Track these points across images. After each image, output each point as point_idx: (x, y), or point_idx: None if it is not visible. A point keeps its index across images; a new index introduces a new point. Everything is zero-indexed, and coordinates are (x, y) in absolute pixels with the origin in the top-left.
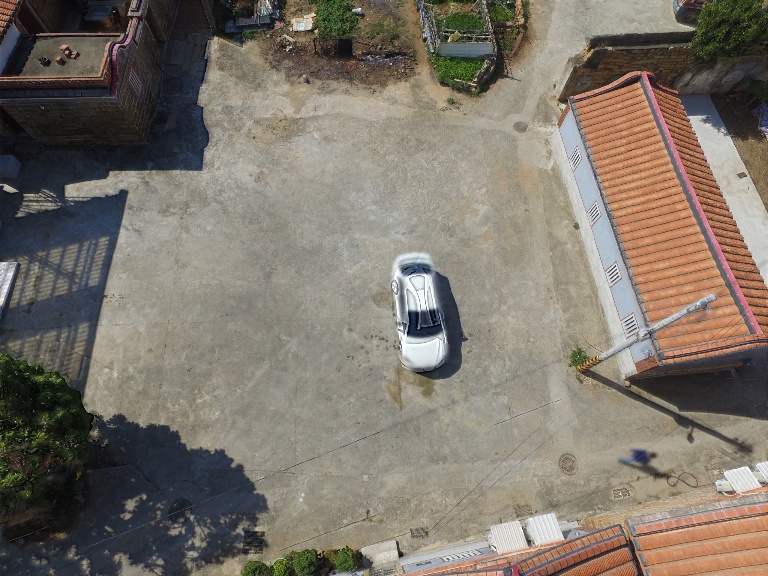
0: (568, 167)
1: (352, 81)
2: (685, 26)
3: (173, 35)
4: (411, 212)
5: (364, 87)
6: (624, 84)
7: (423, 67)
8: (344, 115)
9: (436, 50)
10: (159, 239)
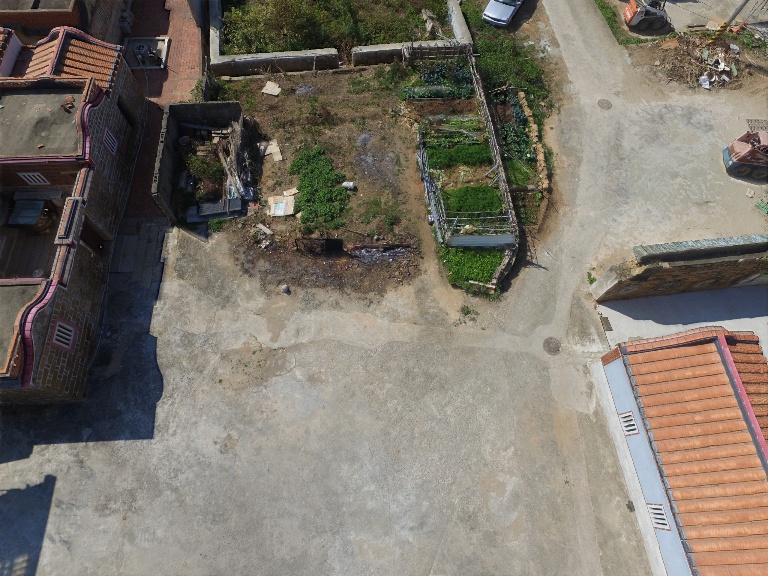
0: (617, 424)
1: (343, 288)
2: (738, 181)
3: (122, 227)
4: (420, 492)
5: (358, 297)
6: (693, 342)
7: (430, 262)
8: (334, 342)
9: (445, 240)
10: (94, 556)
